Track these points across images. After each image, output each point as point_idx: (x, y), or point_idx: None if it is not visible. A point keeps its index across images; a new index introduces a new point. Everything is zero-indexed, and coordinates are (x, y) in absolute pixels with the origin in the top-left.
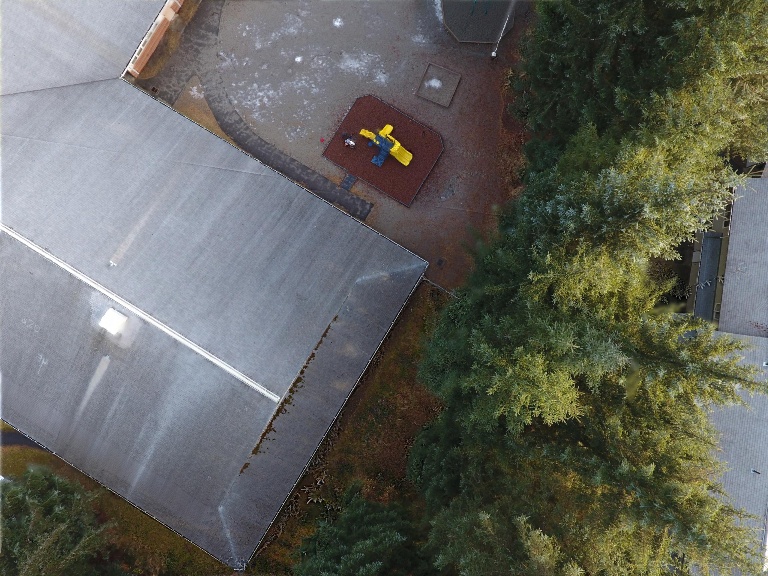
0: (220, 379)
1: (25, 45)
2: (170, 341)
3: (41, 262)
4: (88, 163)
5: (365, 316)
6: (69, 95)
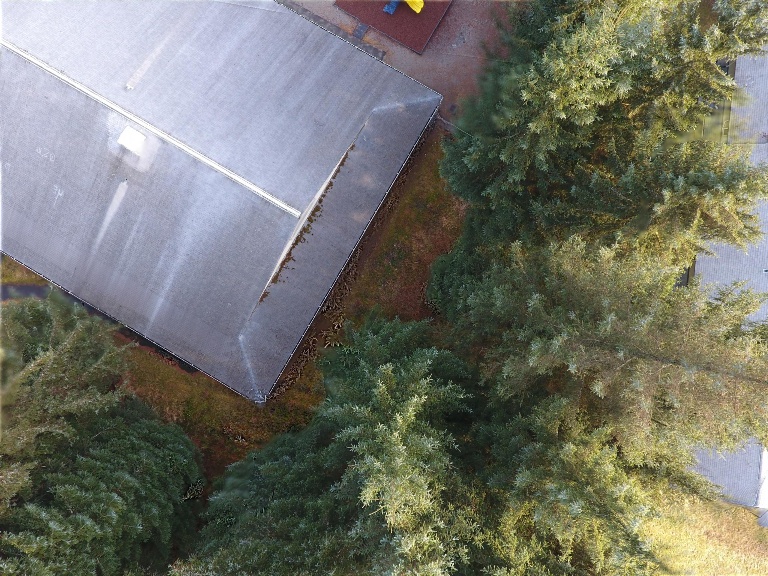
0: (240, 197)
1: None
2: (189, 160)
3: (57, 85)
4: None
5: (382, 147)
6: None
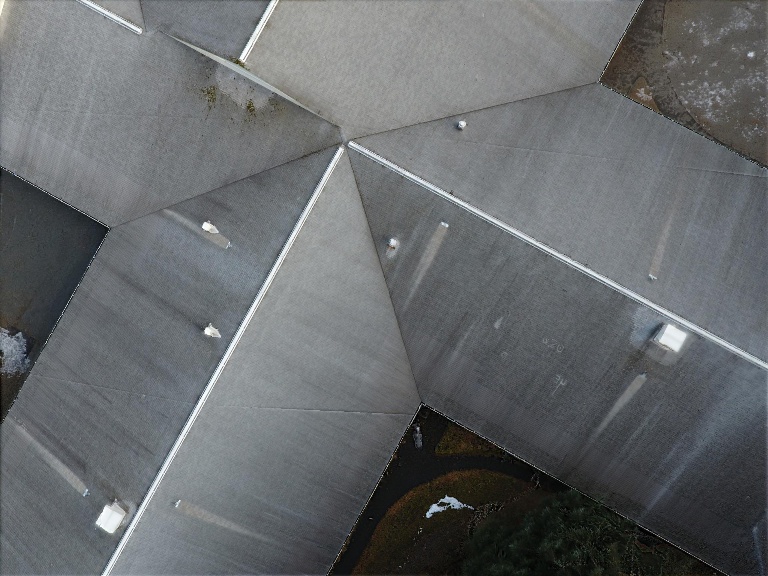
0: None
1: (517, 52)
2: (728, 356)
3: (580, 279)
4: (596, 173)
5: None
6: (556, 102)
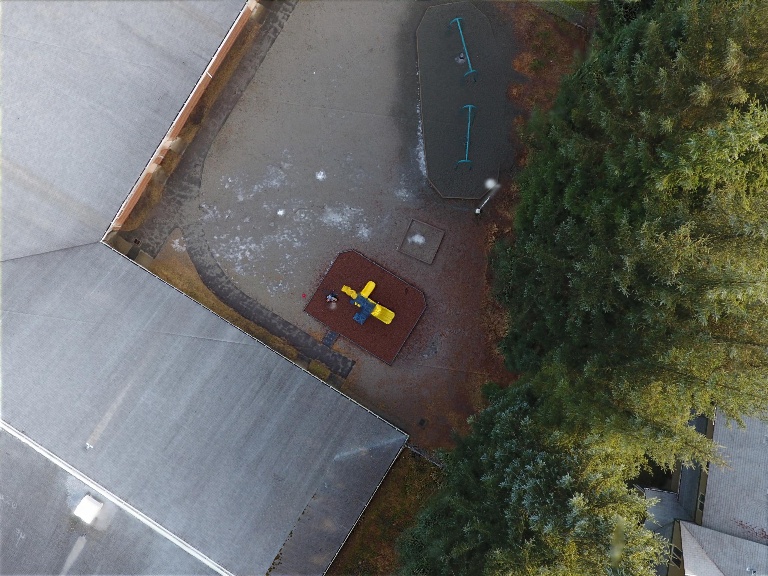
0: (195, 567)
1: (5, 215)
2: (145, 528)
3: (18, 444)
4: (67, 336)
5: (343, 491)
6: (49, 262)
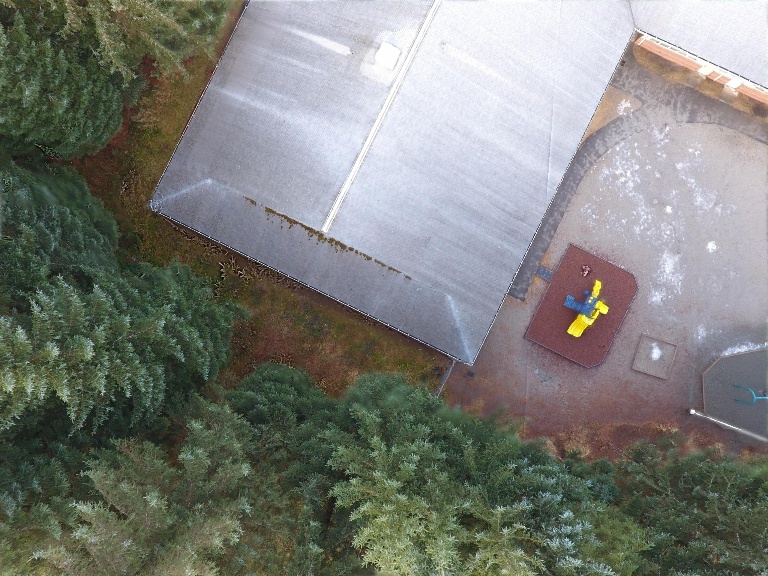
0: (339, 170)
1: None
2: (373, 115)
3: None
4: (545, 8)
5: (413, 307)
6: None
